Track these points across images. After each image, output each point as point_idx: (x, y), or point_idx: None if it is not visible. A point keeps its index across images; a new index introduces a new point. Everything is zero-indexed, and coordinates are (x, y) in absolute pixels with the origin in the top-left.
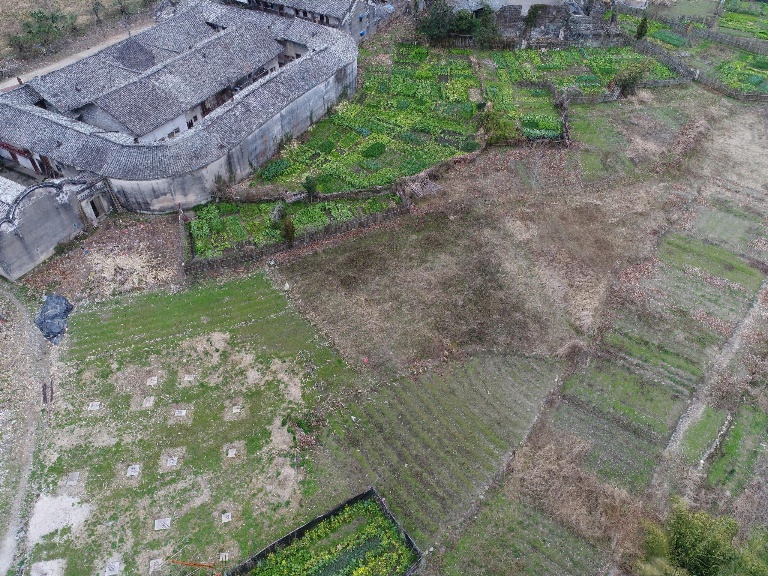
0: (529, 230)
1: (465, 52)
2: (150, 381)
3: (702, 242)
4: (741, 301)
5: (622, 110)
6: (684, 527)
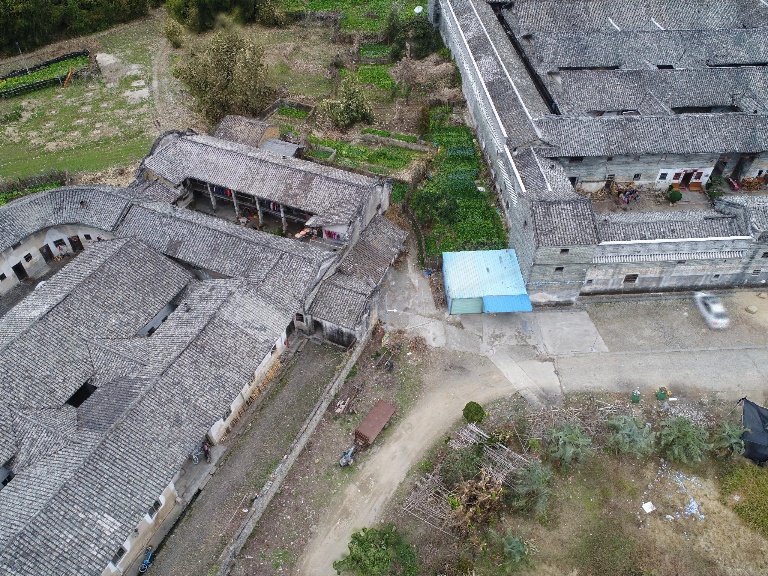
0: None
1: None
2: (98, 131)
3: None
4: None
5: None
6: None
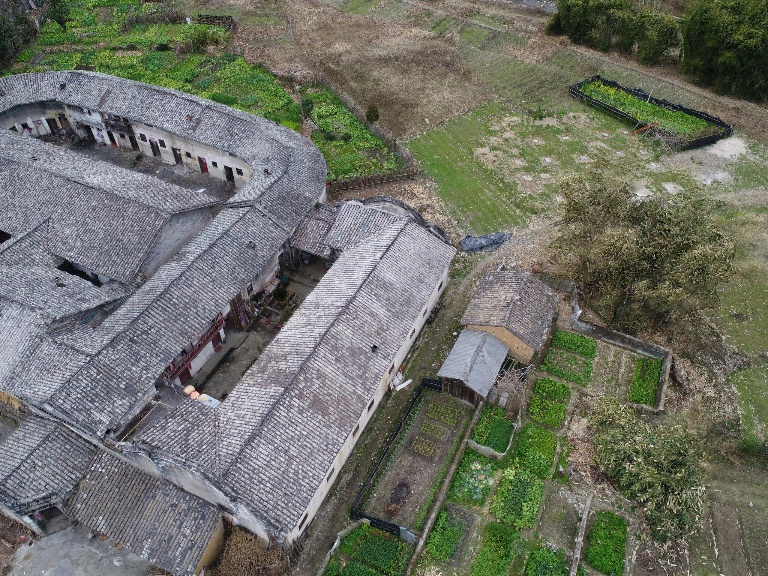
0: (342, 45)
1: (28, 53)
2: (528, 178)
3: (346, 4)
4: (397, 2)
5: (184, 2)
6: (568, 2)
